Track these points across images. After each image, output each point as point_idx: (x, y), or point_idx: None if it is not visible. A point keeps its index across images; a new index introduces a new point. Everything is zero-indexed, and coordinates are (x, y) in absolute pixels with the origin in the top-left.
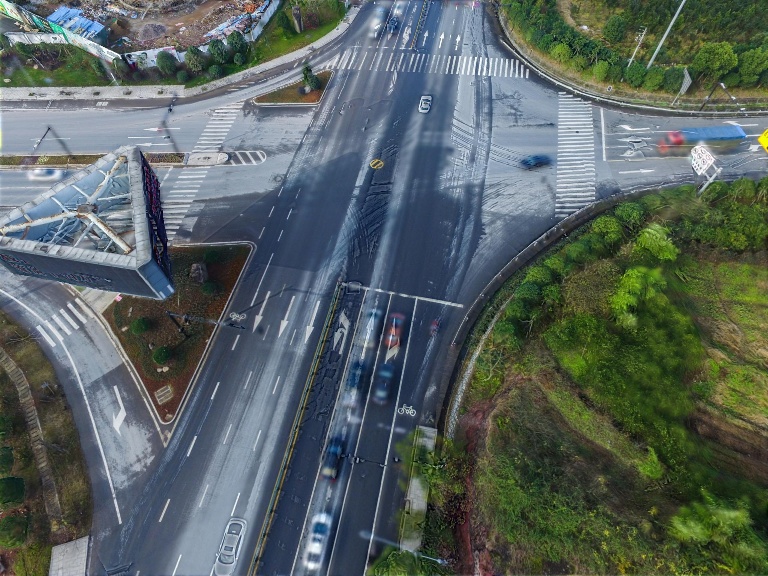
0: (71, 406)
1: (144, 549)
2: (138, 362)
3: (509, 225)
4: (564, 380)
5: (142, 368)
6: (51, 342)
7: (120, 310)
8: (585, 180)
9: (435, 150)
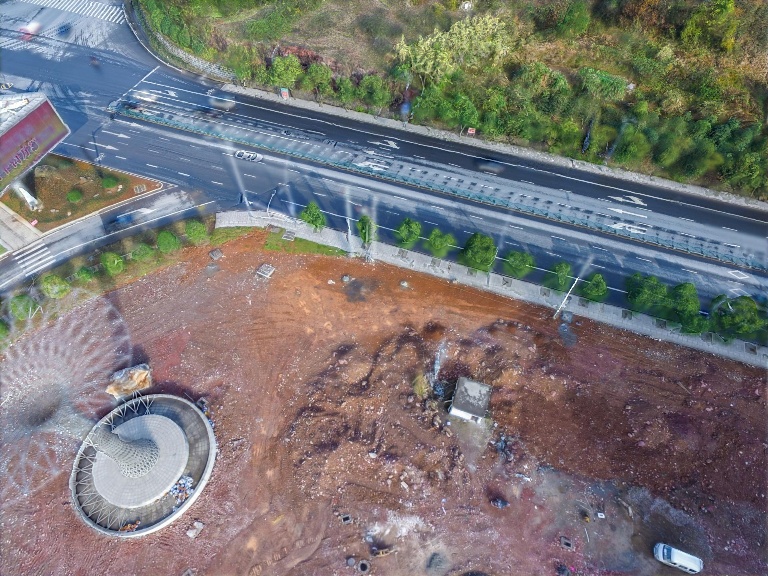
0: (119, 239)
1: (234, 189)
2: (105, 204)
3: (114, 40)
4: (221, 17)
5: (111, 201)
6: (50, 263)
7: (48, 217)
8: (103, 7)
9: (19, 58)
